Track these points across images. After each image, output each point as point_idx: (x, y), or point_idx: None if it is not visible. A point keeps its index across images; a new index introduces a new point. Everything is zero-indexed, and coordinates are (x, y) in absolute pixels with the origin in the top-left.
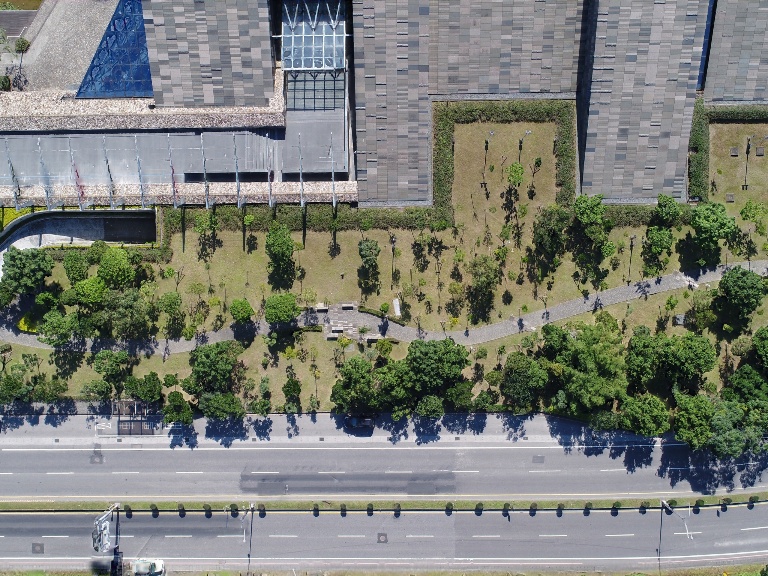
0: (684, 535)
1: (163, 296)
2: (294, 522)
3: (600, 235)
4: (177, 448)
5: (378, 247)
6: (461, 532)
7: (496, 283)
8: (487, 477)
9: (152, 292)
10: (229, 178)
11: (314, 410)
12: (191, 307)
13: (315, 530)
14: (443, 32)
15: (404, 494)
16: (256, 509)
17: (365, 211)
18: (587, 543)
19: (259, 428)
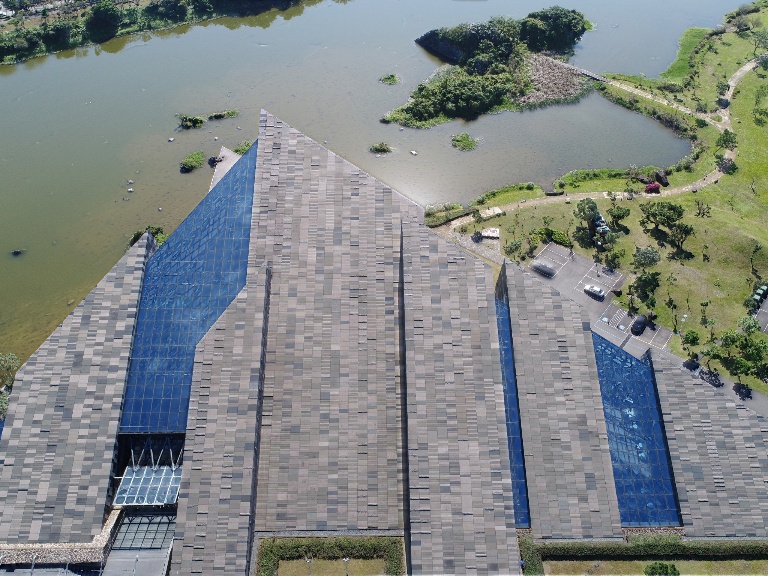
0: None
1: None
2: None
3: None
4: None
5: None
6: None
7: None
8: None
9: None
10: None
11: None
12: None
13: None
14: (273, 472)
15: None
16: None
17: None
18: None
19: None
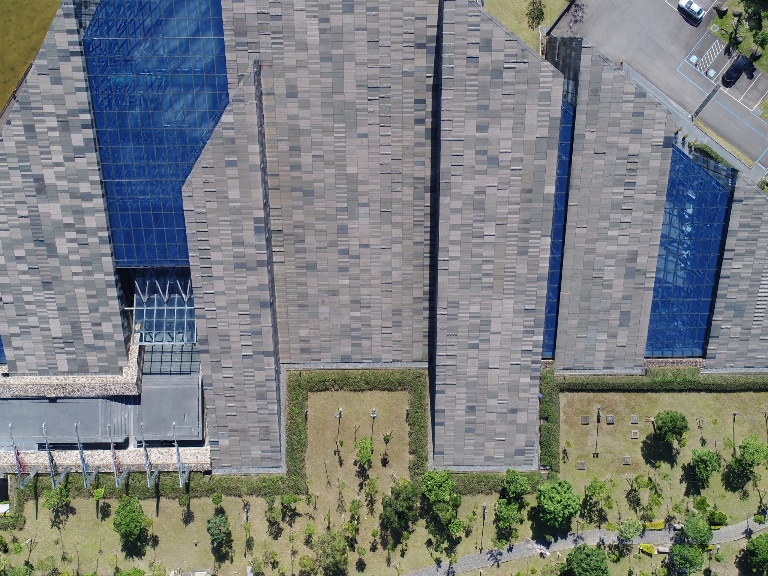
0: None
1: (11, 573)
2: None
3: (447, 513)
4: None
5: (227, 523)
6: None
7: (345, 559)
8: None
9: (0, 567)
10: None
11: None
12: (44, 575)
13: None
14: (292, 310)
15: None
16: None
17: (218, 479)
18: None
19: None
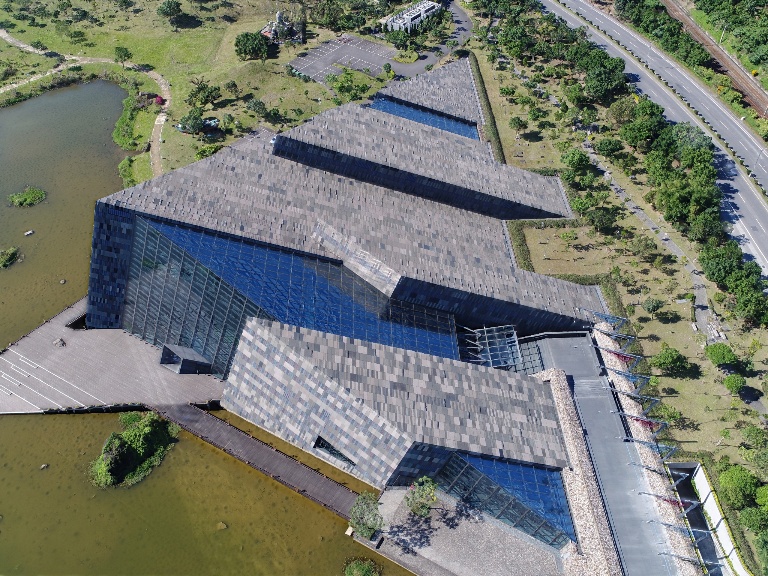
0: (765, 170)
1: (750, 439)
2: None
3: None
4: None
5: None
6: None
7: None
8: None
9: None
10: None
11: None
12: None
13: None
14: None
15: None
16: None
17: None
18: None
19: None
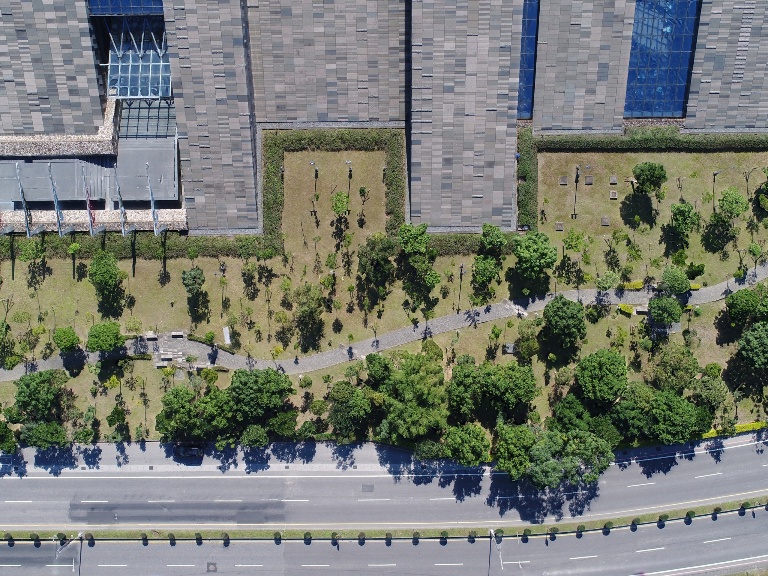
0: (513, 564)
1: None
2: (123, 551)
3: (423, 264)
4: (6, 477)
5: (202, 276)
6: (290, 561)
7: (321, 312)
8: (316, 506)
9: None
10: (59, 206)
11: (143, 439)
12: (20, 335)
13: (144, 559)
14: (267, 61)
15: (233, 523)
16: (85, 538)
17: (195, 239)
18: (416, 572)
19: (88, 457)
